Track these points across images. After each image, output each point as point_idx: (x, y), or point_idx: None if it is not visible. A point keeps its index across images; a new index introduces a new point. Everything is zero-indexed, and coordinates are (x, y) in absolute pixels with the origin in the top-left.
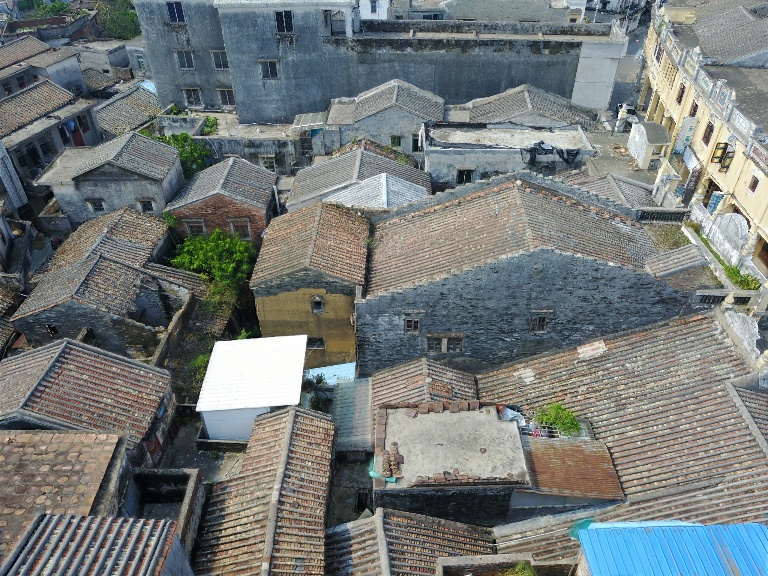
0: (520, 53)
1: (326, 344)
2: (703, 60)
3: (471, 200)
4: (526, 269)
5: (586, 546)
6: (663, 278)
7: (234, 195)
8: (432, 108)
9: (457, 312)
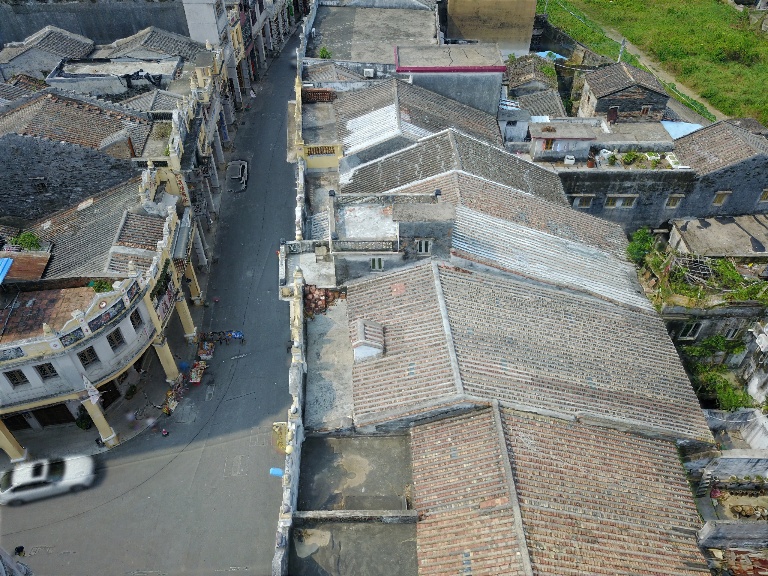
0: (137, 2)
1: None
2: (330, 2)
3: (19, 110)
4: (7, 148)
5: None
6: (103, 151)
7: None
8: (77, 48)
9: None
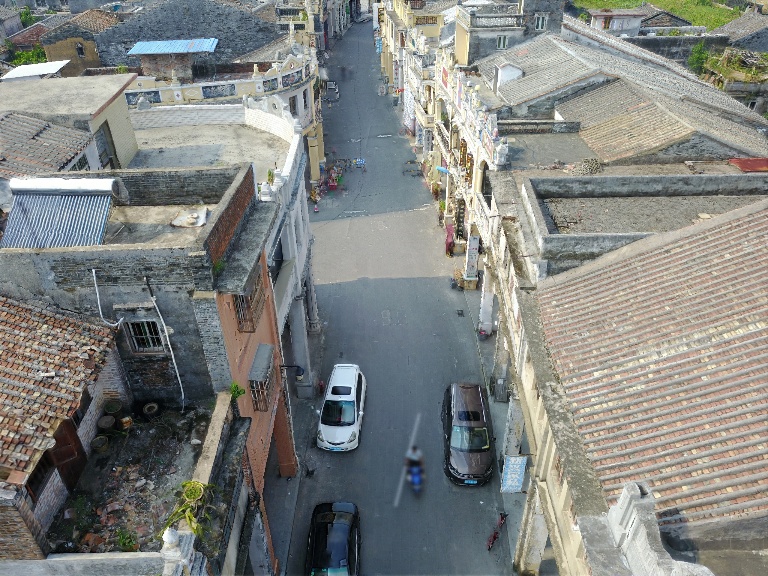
0: None
1: None
2: None
3: None
4: (180, 8)
5: None
6: (255, 13)
7: (50, 26)
8: None
9: None
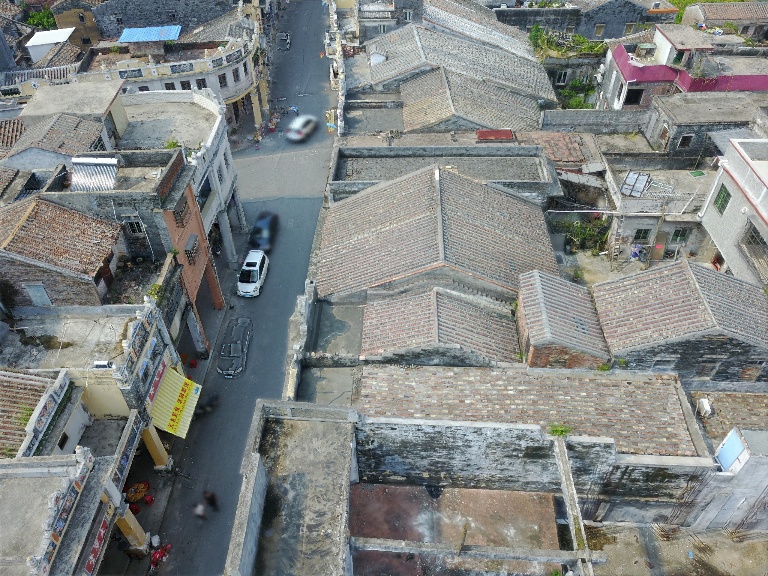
0: None
1: (92, 42)
2: None
3: None
4: None
5: (125, 30)
6: None
7: None
8: None
9: (136, 12)
